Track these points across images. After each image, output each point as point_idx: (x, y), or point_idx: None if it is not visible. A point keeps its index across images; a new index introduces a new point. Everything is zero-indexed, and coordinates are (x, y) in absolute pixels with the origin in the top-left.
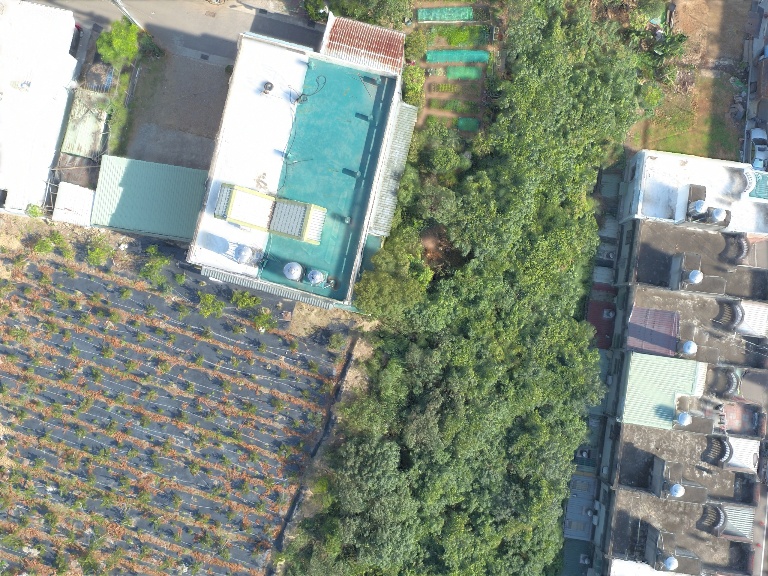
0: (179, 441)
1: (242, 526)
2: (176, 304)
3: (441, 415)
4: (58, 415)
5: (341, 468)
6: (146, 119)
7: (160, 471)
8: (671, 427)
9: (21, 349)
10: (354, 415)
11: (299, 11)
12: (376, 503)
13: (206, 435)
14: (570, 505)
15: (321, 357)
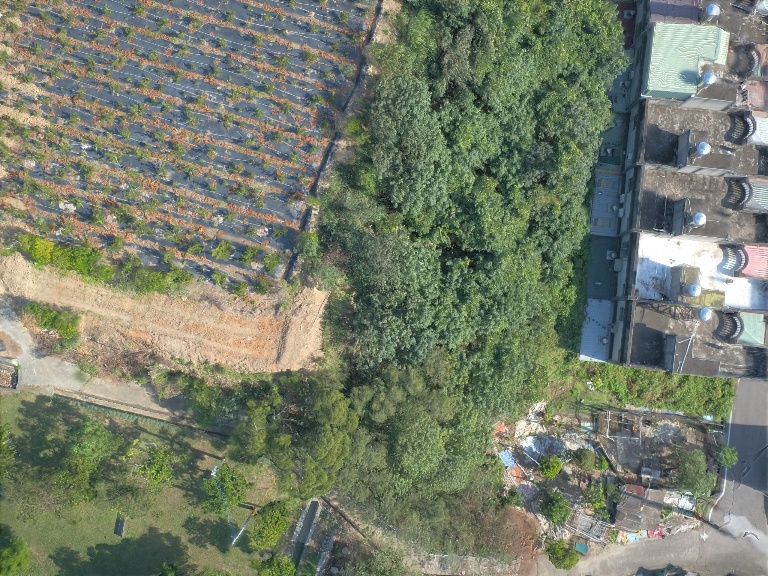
0: (212, 97)
1: (276, 176)
2: None
3: (471, 53)
4: (91, 75)
5: (374, 102)
6: None
7: (194, 126)
8: (696, 91)
9: (54, 12)
10: (385, 55)
11: None
12: (410, 132)
13: (238, 91)
14: (595, 203)
15: (350, 12)
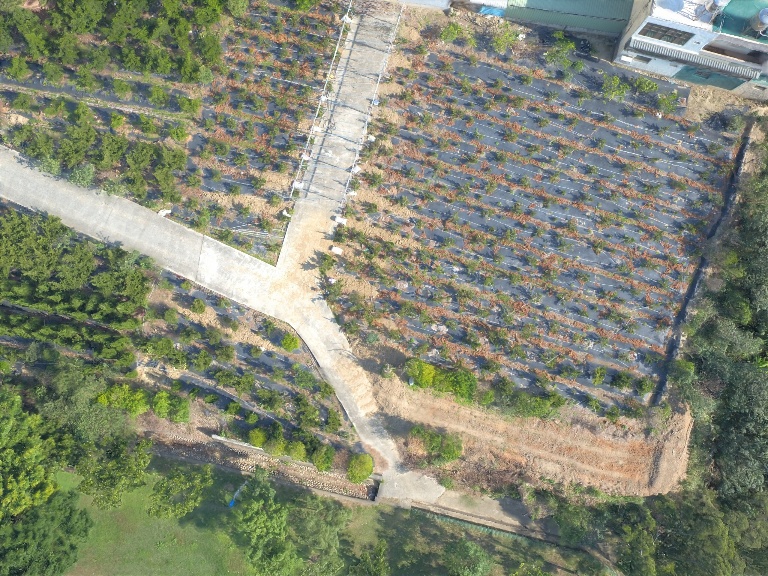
0: (581, 222)
1: (646, 303)
2: (575, 91)
3: None
4: (462, 198)
5: (759, 237)
6: None
7: (564, 251)
8: None
9: (425, 135)
10: (765, 189)
11: None
12: None
13: (607, 217)
14: None
15: (718, 141)
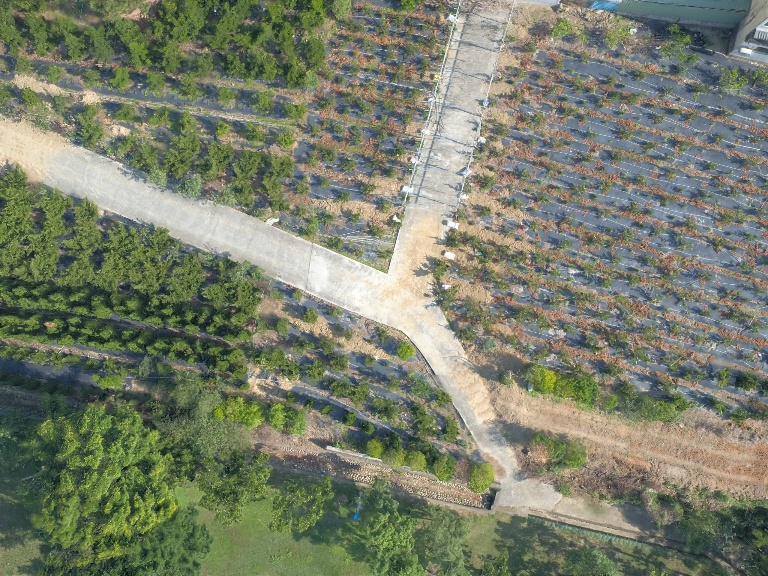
0: (700, 220)
1: None
2: (690, 86)
3: None
4: (576, 199)
5: None
6: None
7: (683, 250)
8: None
9: (536, 135)
10: None
11: None
12: None
13: (726, 214)
14: None
15: None
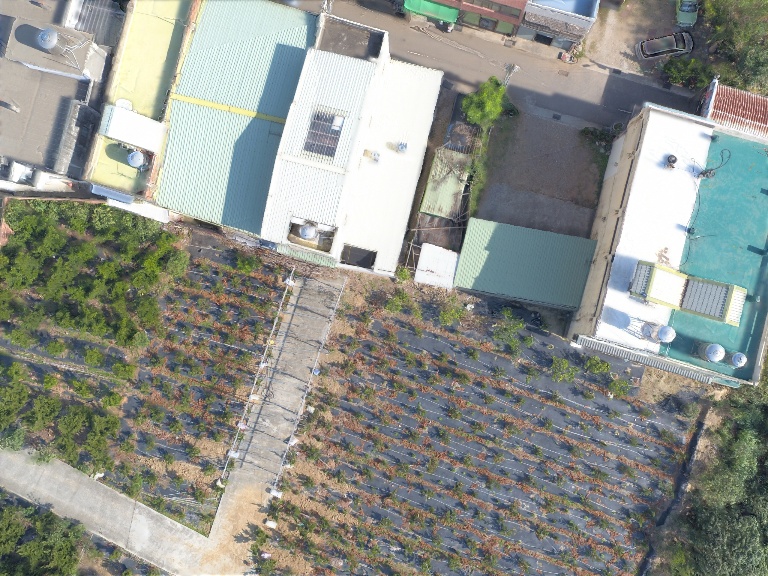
0: (525, 505)
1: None
2: (523, 367)
3: None
4: (402, 474)
5: (706, 542)
6: (497, 179)
7: (505, 535)
8: None
9: (366, 407)
10: (716, 488)
11: (654, 72)
12: None
13: (552, 500)
14: None
15: (671, 425)
